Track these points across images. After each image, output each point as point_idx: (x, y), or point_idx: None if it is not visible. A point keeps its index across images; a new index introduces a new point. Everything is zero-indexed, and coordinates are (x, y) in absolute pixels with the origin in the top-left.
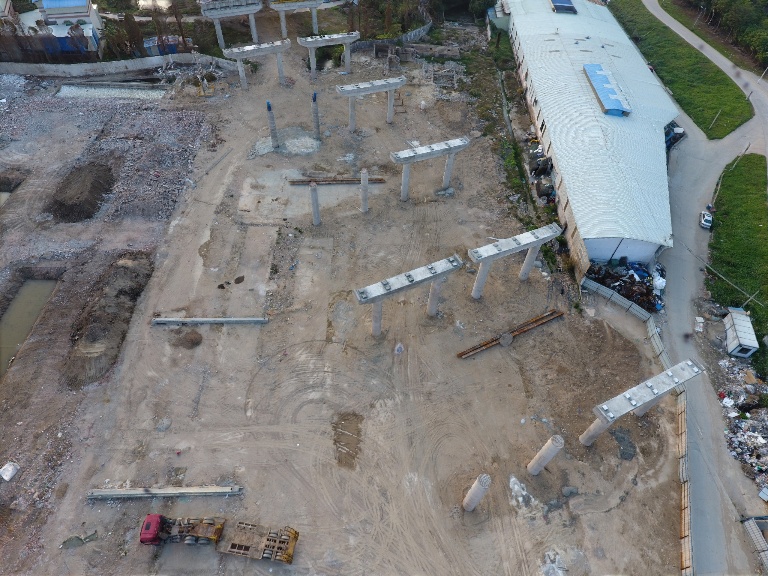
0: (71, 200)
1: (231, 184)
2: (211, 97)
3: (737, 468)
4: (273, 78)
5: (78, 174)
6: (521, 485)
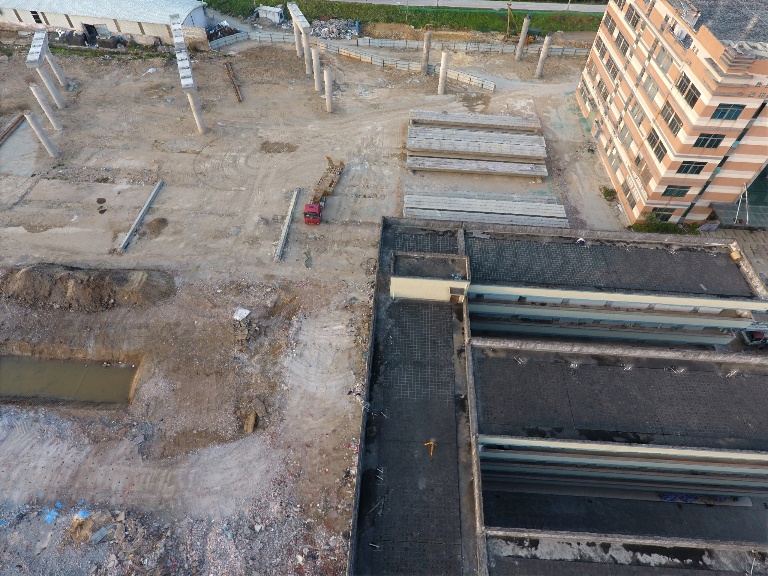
0: None
1: None
2: None
3: (336, 40)
4: None
5: None
6: None
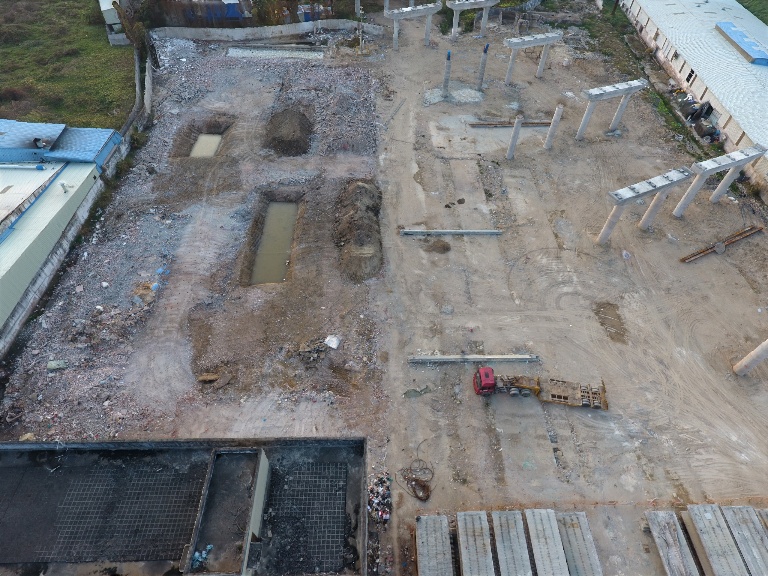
0: (288, 137)
1: (418, 127)
2: (368, 56)
3: None
4: (417, 41)
5: (284, 117)
6: None
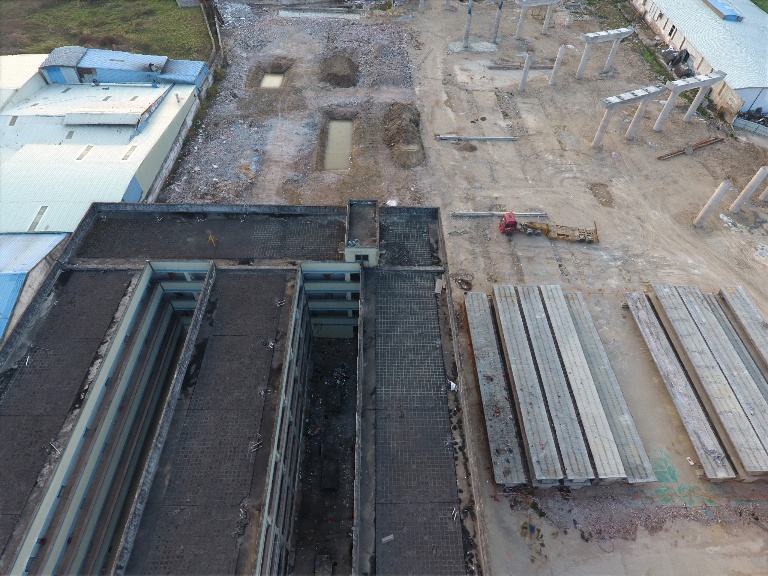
0: (340, 73)
1: (445, 68)
2: (399, 17)
3: None
4: (439, 6)
5: (335, 59)
6: (728, 217)
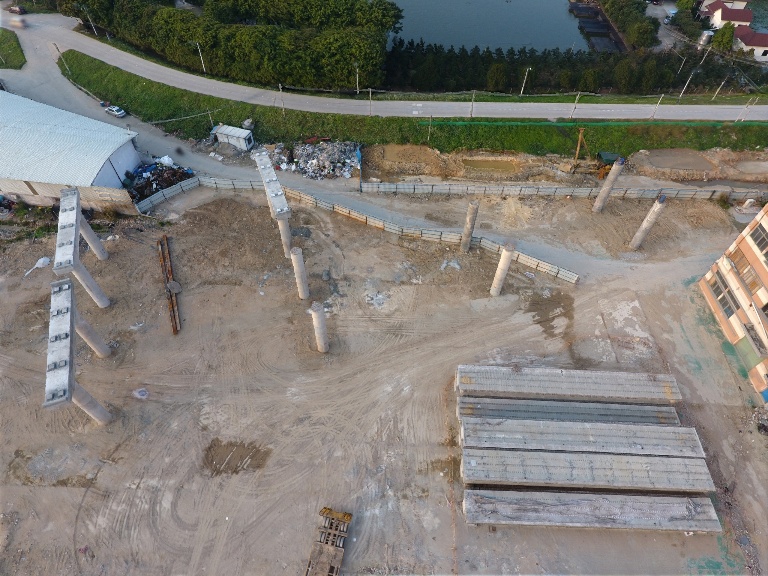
0: None
1: None
2: None
3: (329, 181)
4: None
5: None
6: None
